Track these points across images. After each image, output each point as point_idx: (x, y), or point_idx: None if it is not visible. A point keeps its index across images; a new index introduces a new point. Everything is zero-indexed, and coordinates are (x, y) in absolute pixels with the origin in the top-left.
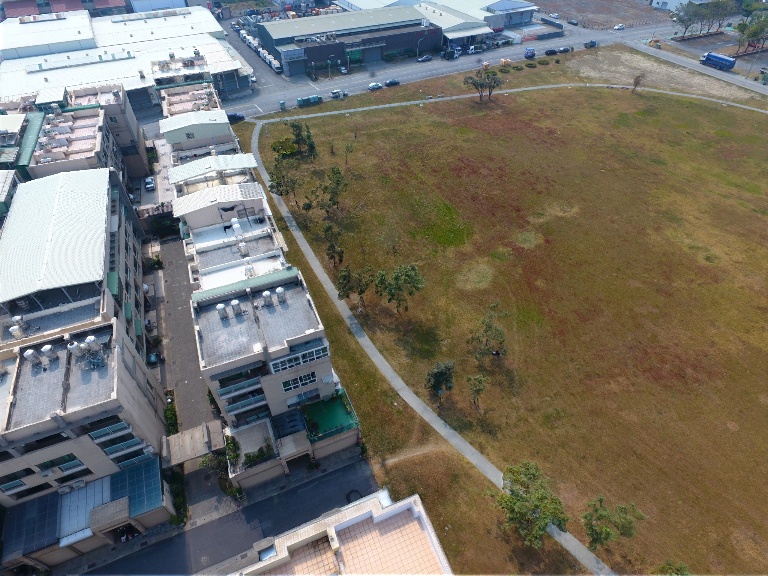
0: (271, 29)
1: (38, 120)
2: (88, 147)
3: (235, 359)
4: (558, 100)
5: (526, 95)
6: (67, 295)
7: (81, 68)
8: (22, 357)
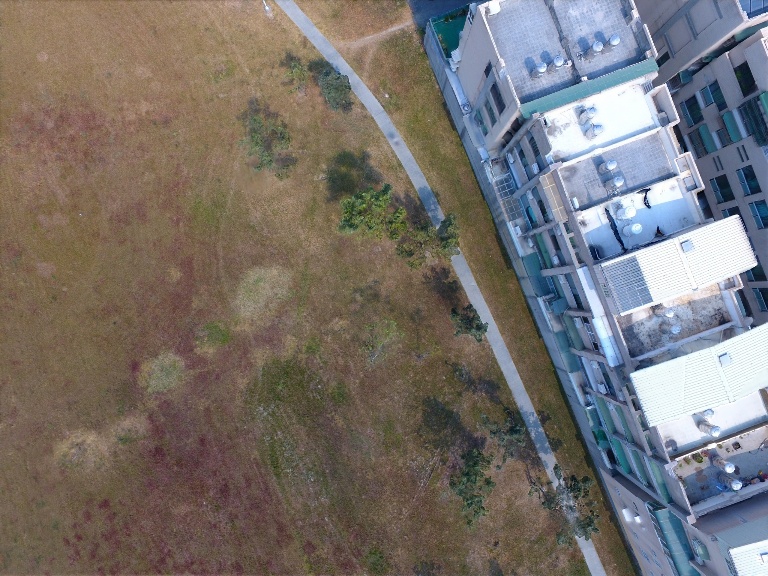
0: None
1: None
2: None
3: None
4: None
5: None
6: None
7: None
8: None
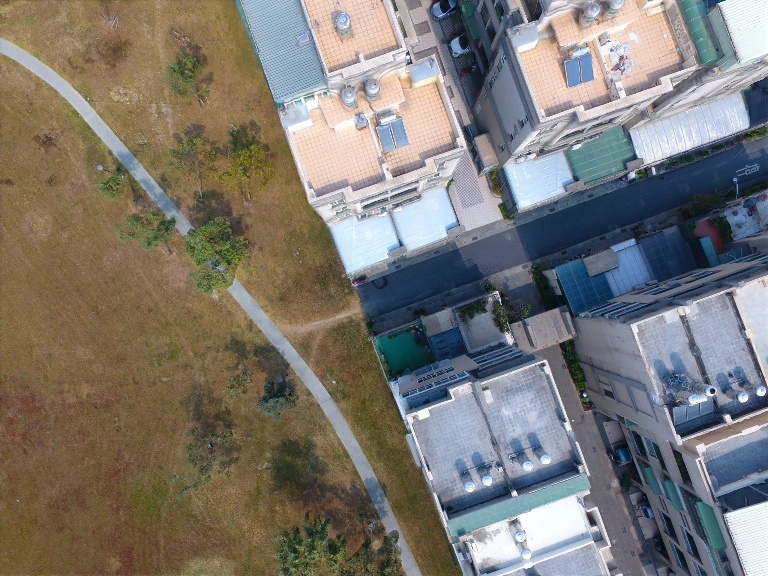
0: None
1: None
2: None
3: None
4: None
5: None
6: (762, 492)
7: None
8: (767, 395)
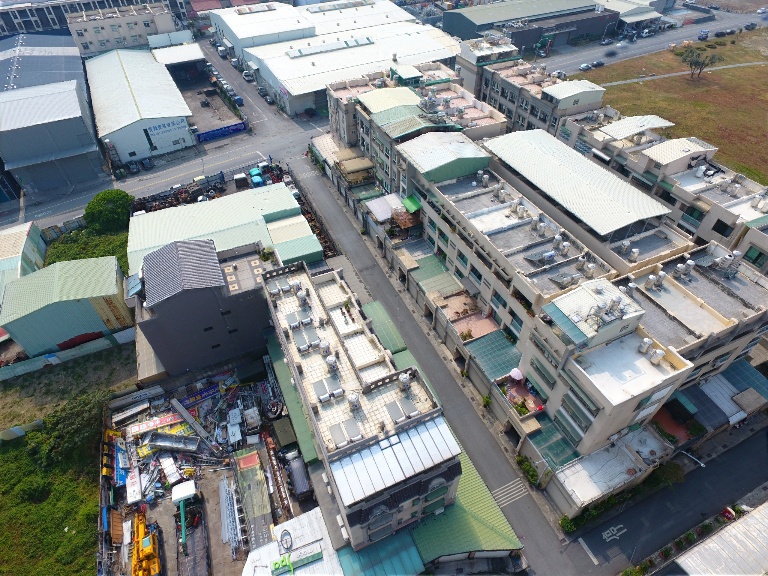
0: (469, 16)
1: (416, 93)
2: (478, 115)
3: None
4: (762, 76)
5: (728, 73)
6: (645, 225)
7: (334, 53)
8: None
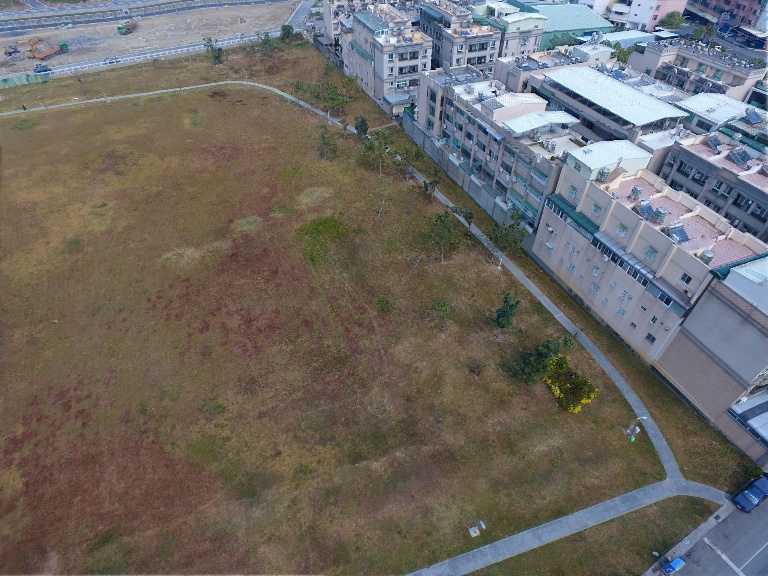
0: None
1: None
2: None
3: (457, 66)
4: None
5: None
6: None
7: None
8: None
